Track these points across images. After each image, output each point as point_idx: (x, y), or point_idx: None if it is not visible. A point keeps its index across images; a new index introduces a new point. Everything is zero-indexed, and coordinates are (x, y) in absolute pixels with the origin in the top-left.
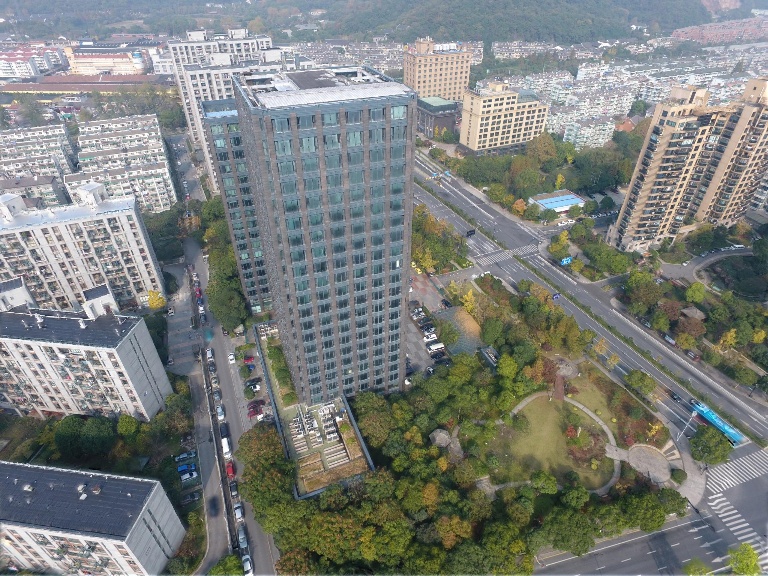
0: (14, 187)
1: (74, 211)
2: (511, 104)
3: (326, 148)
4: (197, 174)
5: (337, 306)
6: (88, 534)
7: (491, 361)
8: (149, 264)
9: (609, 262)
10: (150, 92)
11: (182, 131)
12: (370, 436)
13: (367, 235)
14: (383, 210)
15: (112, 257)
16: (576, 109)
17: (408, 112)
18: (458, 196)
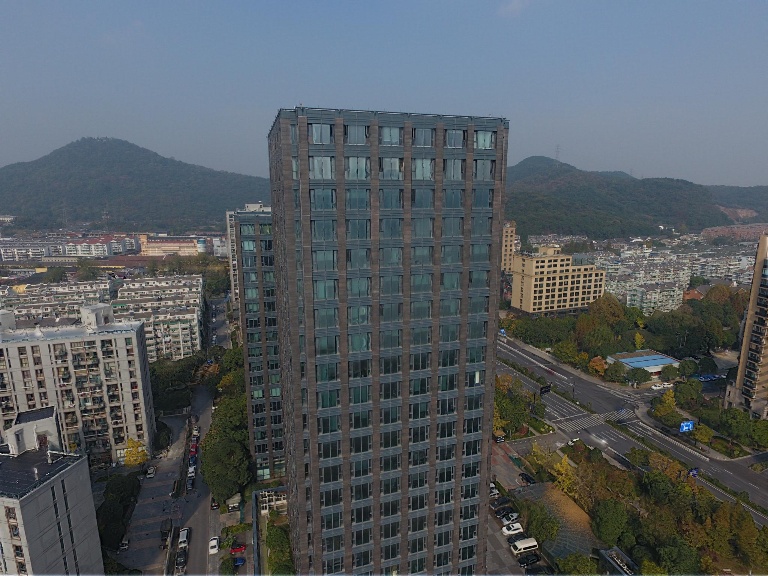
0: (31, 327)
1: (67, 332)
2: (565, 266)
3: (381, 177)
4: (229, 329)
5: (381, 443)
6: None
7: (623, 573)
8: (139, 404)
9: (749, 430)
10: (203, 261)
11: (225, 295)
12: None
13: (434, 322)
14: (458, 285)
15: (95, 391)
16: (633, 278)
17: (497, 141)
18: (518, 356)
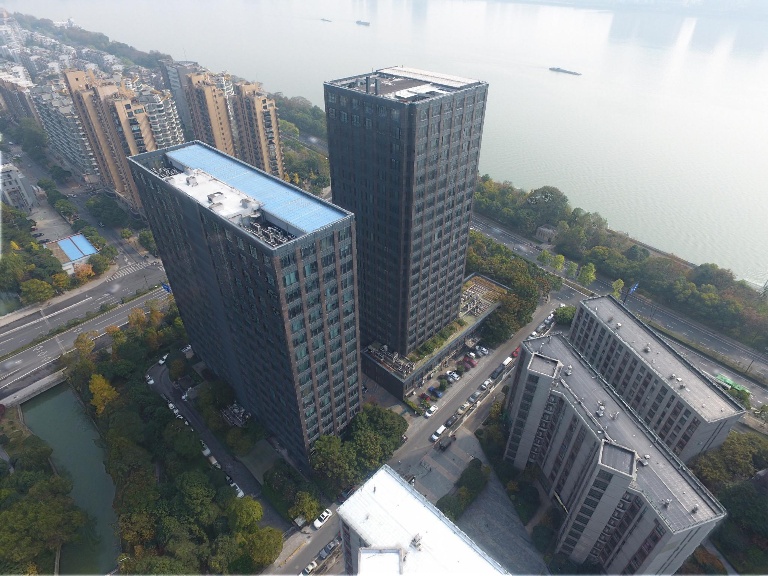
0: None
1: None
2: None
3: None
4: None
5: None
6: (624, 311)
7: None
8: None
9: None
10: None
11: None
12: None
13: None
14: None
15: None
16: None
17: None
18: (7, 337)
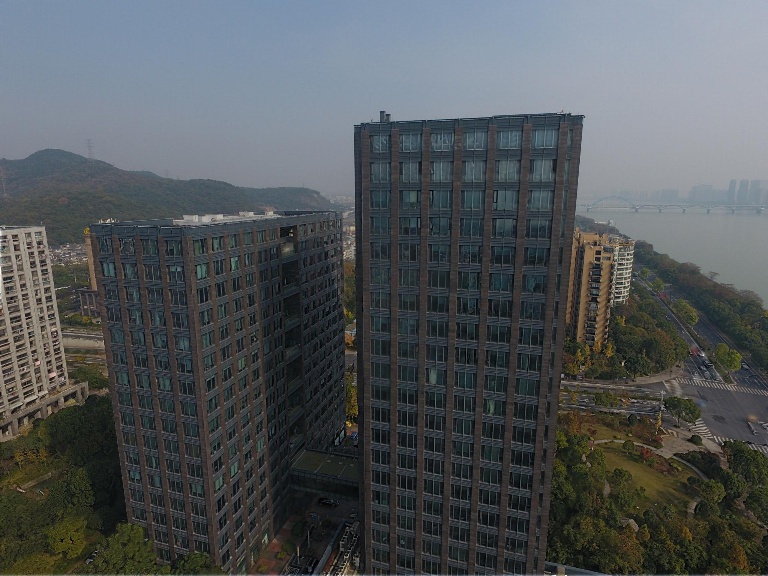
0: None
1: None
2: None
3: None
4: None
5: None
6: None
7: None
8: None
9: None
10: None
11: None
12: (631, 569)
13: None
14: None
15: None
16: None
17: None
18: None
